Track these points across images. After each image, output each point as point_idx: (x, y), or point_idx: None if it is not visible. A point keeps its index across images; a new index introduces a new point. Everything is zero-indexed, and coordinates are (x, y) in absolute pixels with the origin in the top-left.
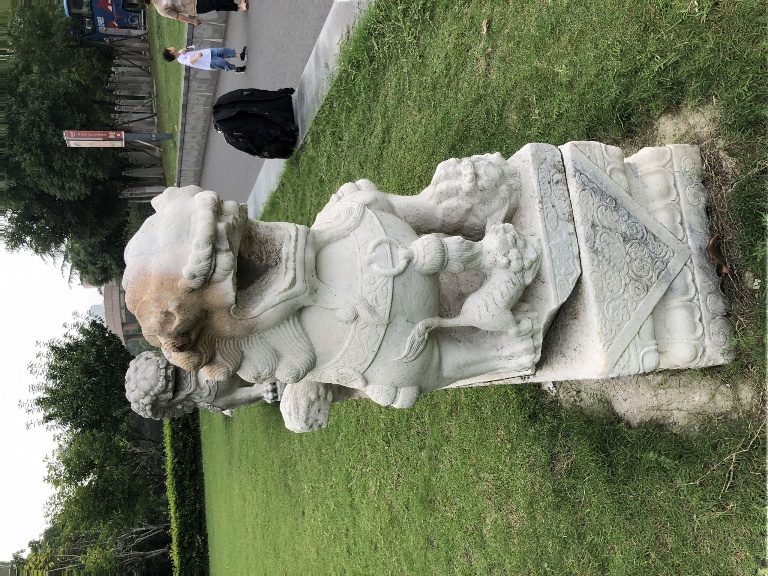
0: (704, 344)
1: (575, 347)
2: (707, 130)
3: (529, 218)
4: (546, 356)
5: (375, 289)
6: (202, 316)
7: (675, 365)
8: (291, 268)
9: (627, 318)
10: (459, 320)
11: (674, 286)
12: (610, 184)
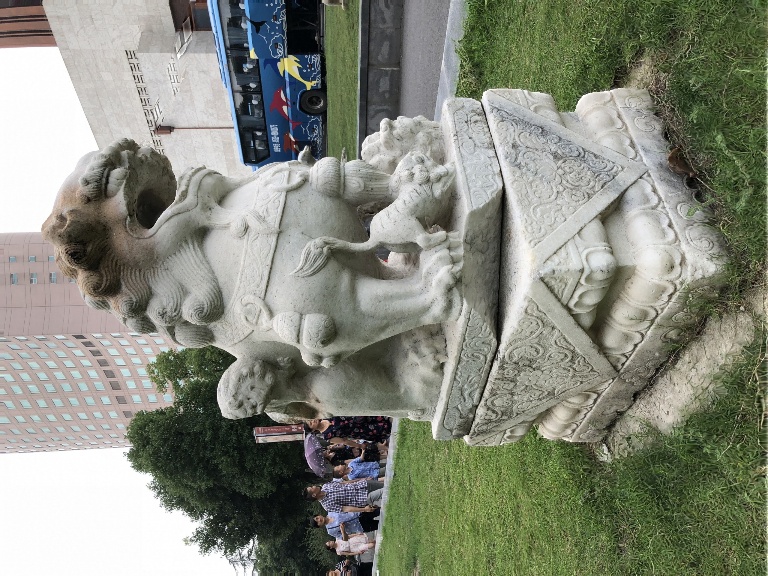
0: (681, 250)
1: (514, 269)
2: (650, 71)
3: (449, 155)
4: (503, 308)
5: (267, 202)
6: (99, 229)
7: (656, 287)
8: (184, 184)
9: (562, 220)
10: (368, 241)
11: (628, 197)
12: (534, 116)
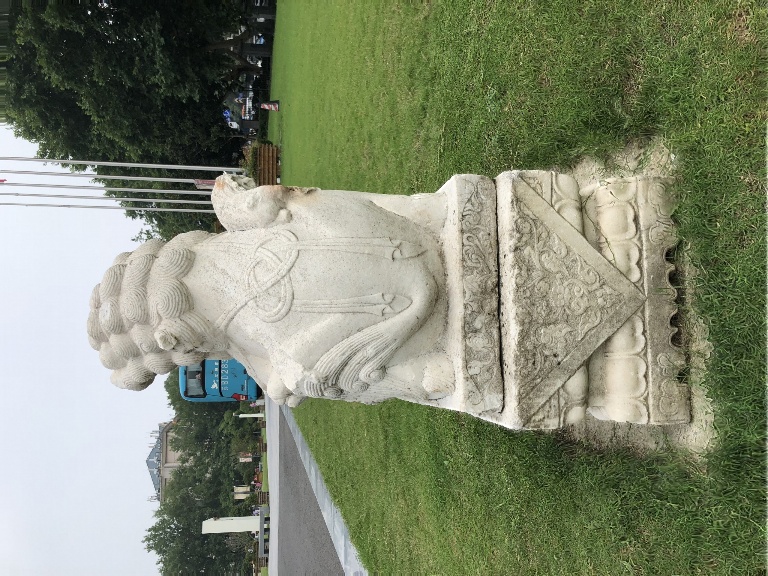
0: None
1: None
2: None
3: None
4: None
5: None
6: None
7: None
8: None
9: None
10: None
11: None
12: None
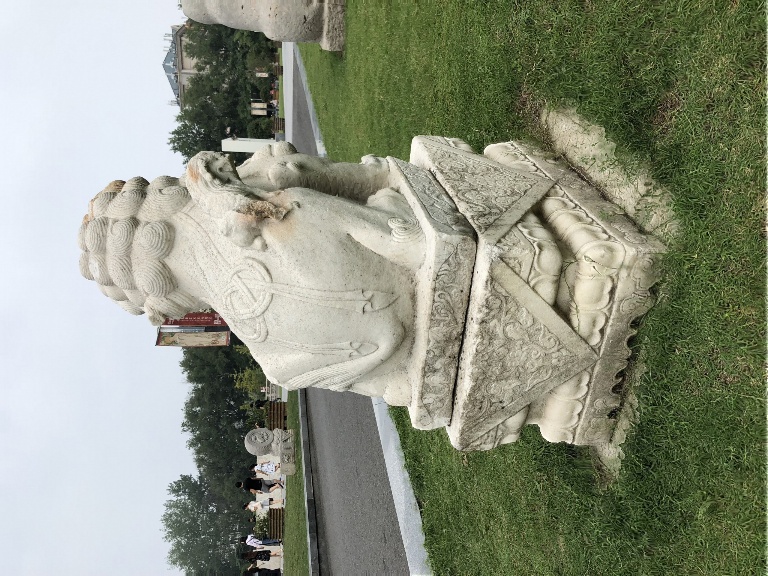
0: None
1: None
2: None
3: None
4: None
5: None
6: None
7: None
8: None
9: None
10: None
11: None
12: None
